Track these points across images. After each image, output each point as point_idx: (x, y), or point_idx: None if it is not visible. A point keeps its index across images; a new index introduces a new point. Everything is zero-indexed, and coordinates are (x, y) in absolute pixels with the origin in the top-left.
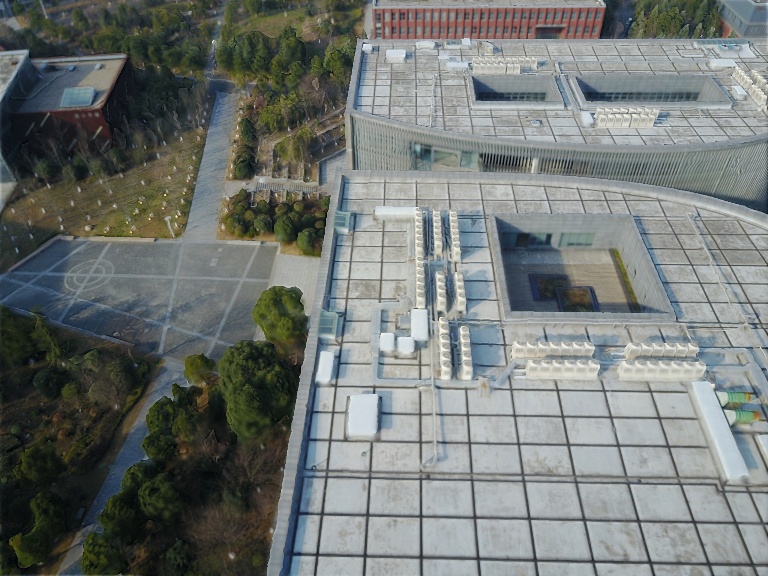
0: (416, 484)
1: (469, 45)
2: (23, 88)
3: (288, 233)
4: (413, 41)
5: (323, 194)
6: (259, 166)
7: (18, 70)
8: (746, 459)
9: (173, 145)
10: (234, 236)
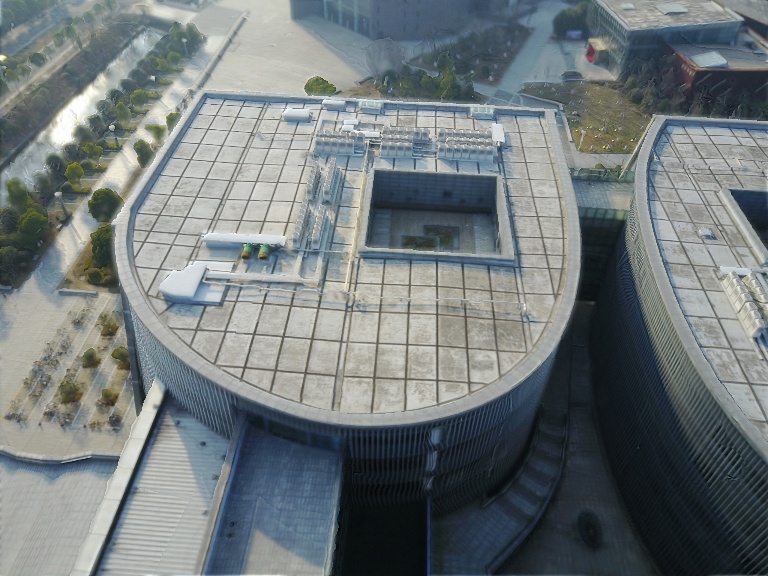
0: (249, 131)
1: None
2: (703, 38)
3: None
4: None
5: None
6: None
7: (711, 23)
8: (219, 252)
9: None
10: None
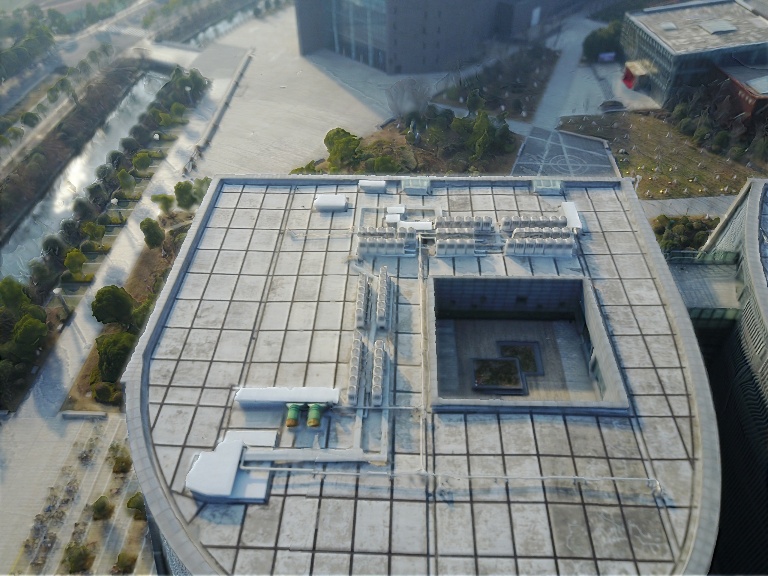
0: (277, 228)
1: None
2: (756, 58)
3: None
4: None
5: None
6: None
7: (766, 42)
8: (256, 415)
9: None
10: None
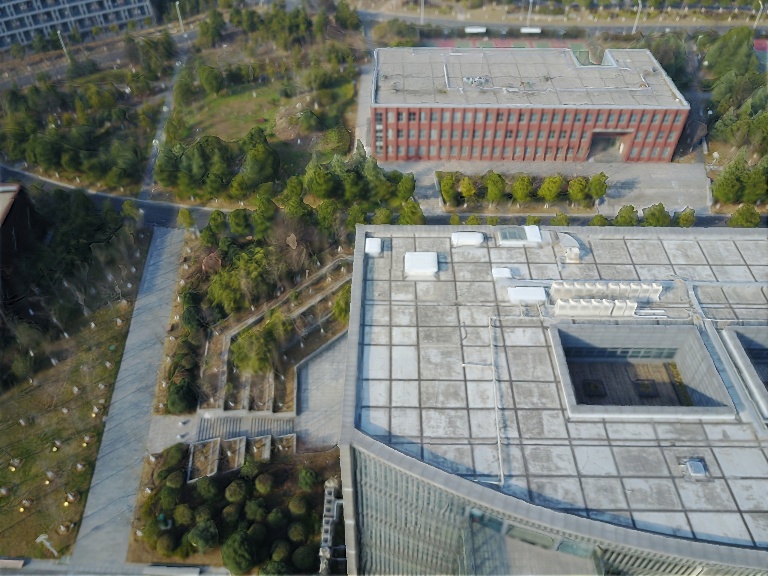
0: None
1: (539, 241)
2: None
3: (243, 568)
4: (447, 230)
5: (303, 434)
6: (205, 388)
7: None
8: None
9: (80, 335)
10: (156, 554)
